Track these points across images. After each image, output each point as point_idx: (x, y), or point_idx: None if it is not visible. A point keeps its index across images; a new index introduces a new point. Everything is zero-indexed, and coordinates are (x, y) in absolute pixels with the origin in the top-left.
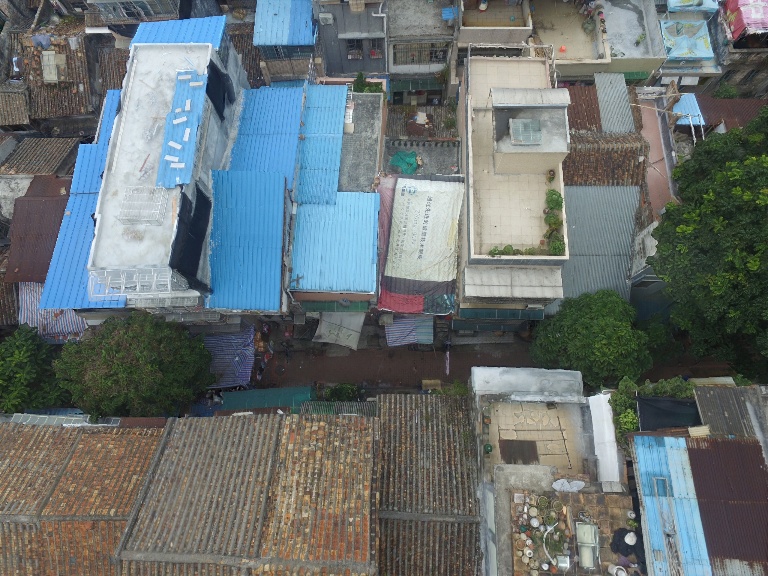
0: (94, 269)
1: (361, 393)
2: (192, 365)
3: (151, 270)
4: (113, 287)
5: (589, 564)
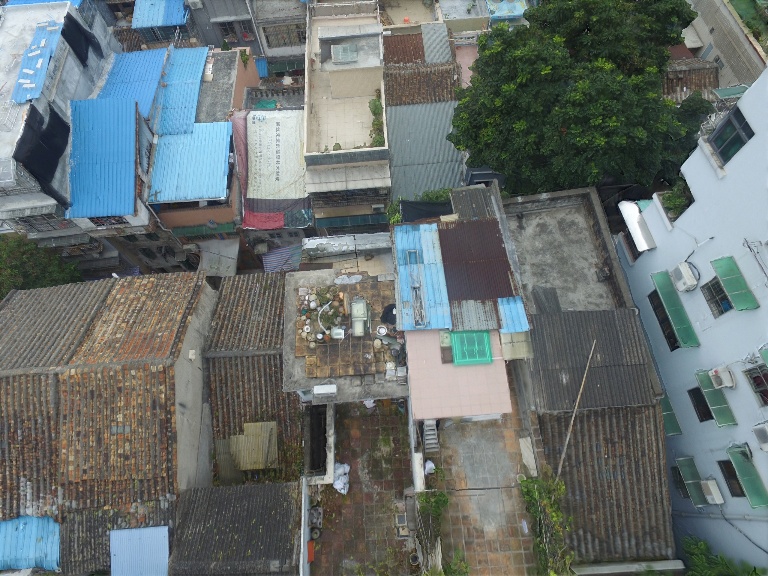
0: None
1: None
2: None
3: None
4: None
5: (361, 333)
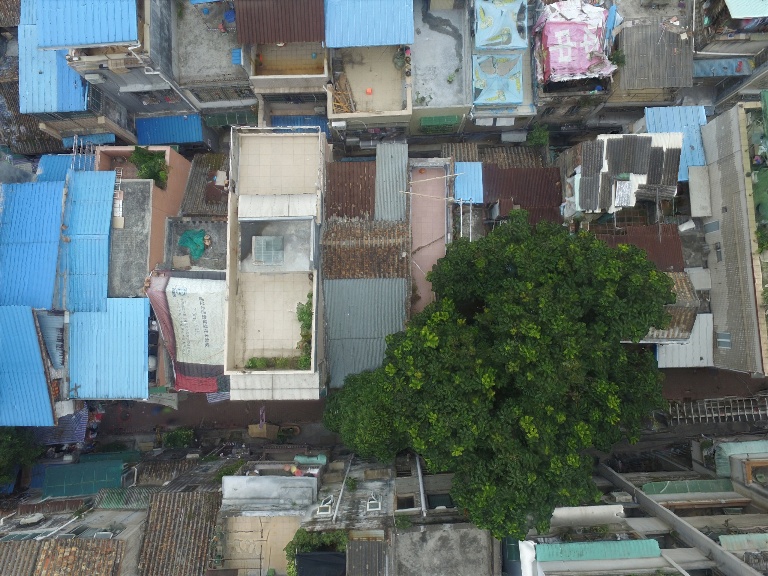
0: None
1: (198, 434)
2: (2, 457)
3: None
4: None
5: None
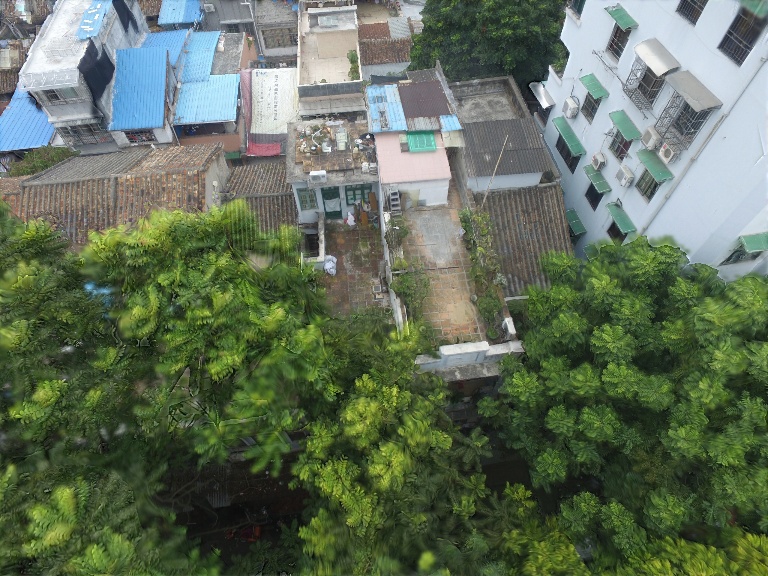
0: (24, 74)
1: None
2: None
3: (64, 72)
4: (37, 104)
5: (343, 148)
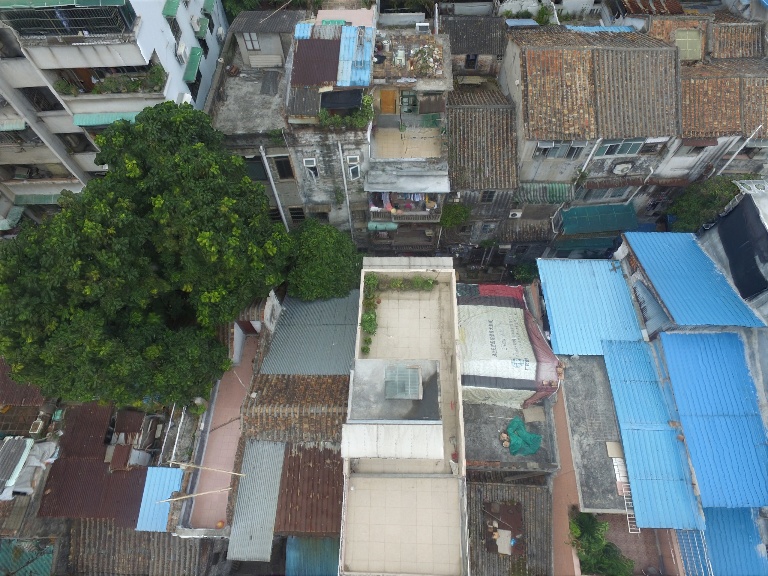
0: None
1: (510, 277)
2: None
3: None
4: None
5: (400, 51)
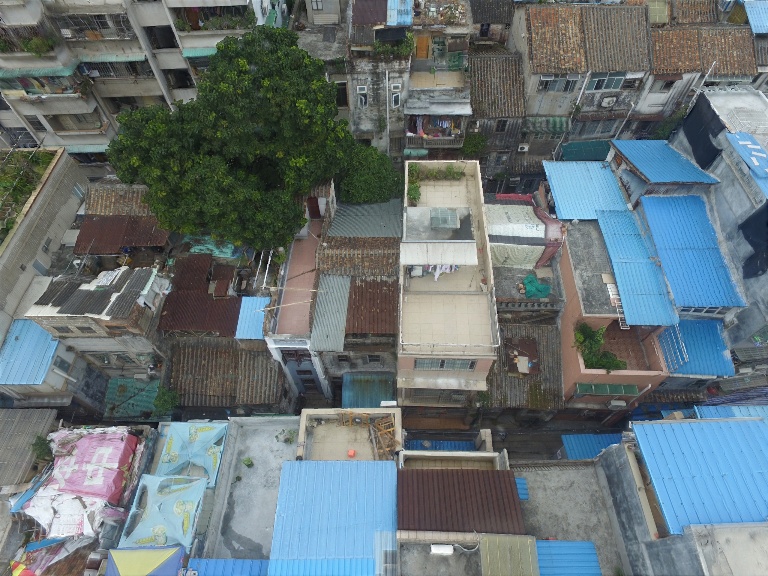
0: None
1: None
2: None
3: None
4: None
5: (432, 8)
